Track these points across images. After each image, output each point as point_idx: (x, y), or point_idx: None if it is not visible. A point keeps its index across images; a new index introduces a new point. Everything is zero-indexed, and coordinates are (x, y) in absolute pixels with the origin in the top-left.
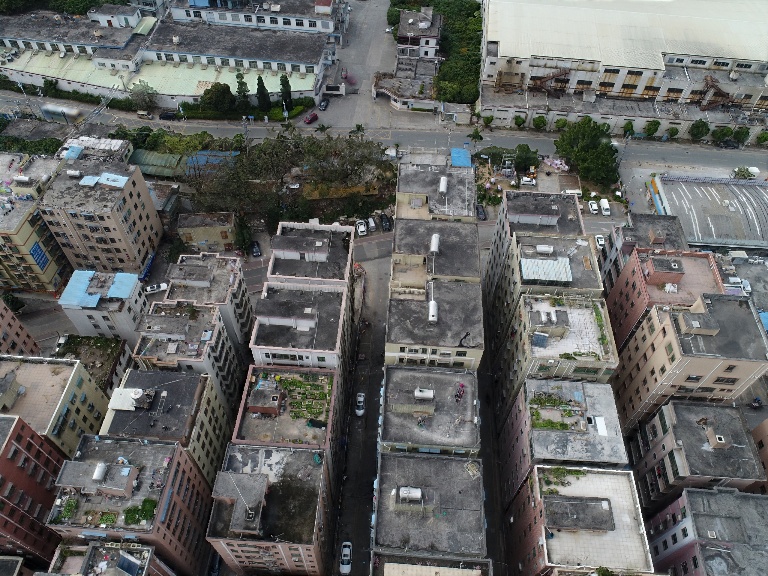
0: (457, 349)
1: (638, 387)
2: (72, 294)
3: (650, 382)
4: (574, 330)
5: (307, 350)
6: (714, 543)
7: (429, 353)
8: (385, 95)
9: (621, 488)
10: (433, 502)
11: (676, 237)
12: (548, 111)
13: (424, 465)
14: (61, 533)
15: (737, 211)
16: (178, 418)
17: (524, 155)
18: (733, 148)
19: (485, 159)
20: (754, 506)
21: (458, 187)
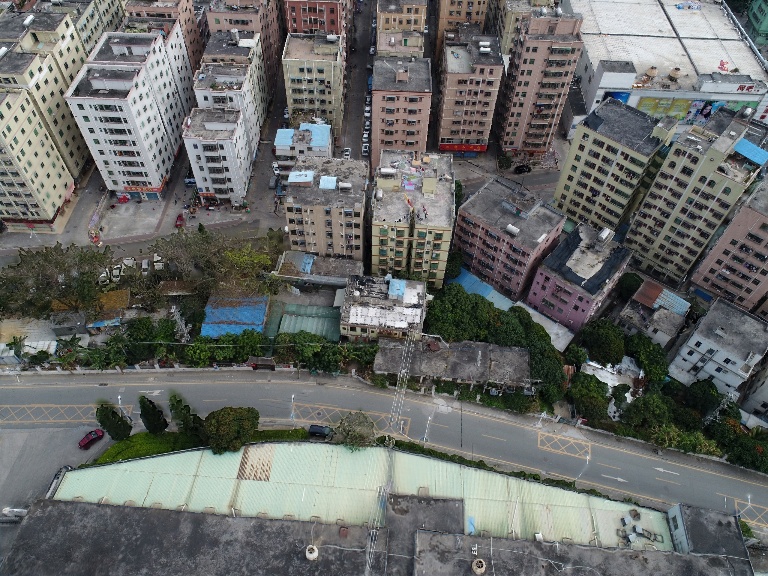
0: None
1: None
2: (322, 130)
3: None
4: None
5: (124, 33)
6: None
7: None
8: None
9: None
10: None
11: None
12: None
13: None
14: None
15: None
16: (215, 38)
17: None
18: None
19: None
20: None
21: None
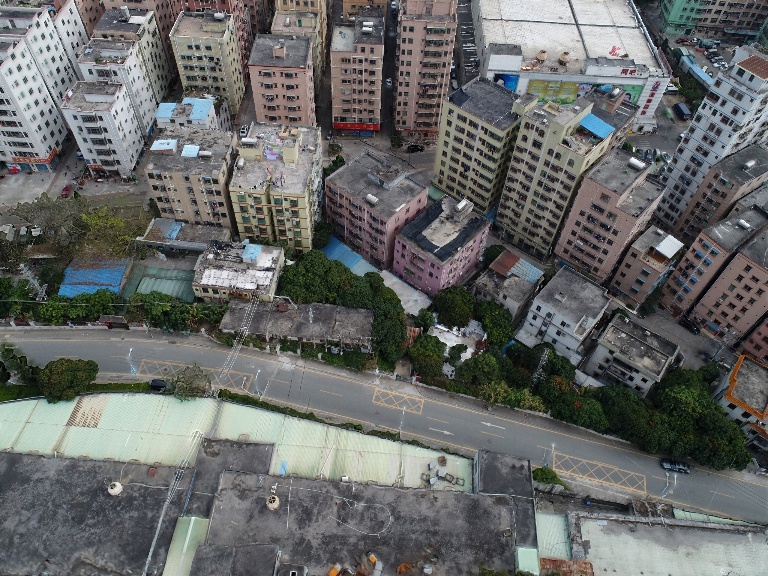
0: None
1: None
2: (203, 104)
3: None
4: None
5: (11, 7)
6: None
7: None
8: None
9: None
10: None
11: None
12: None
13: None
14: None
15: None
16: (107, 15)
17: None
18: None
19: None
20: None
21: None
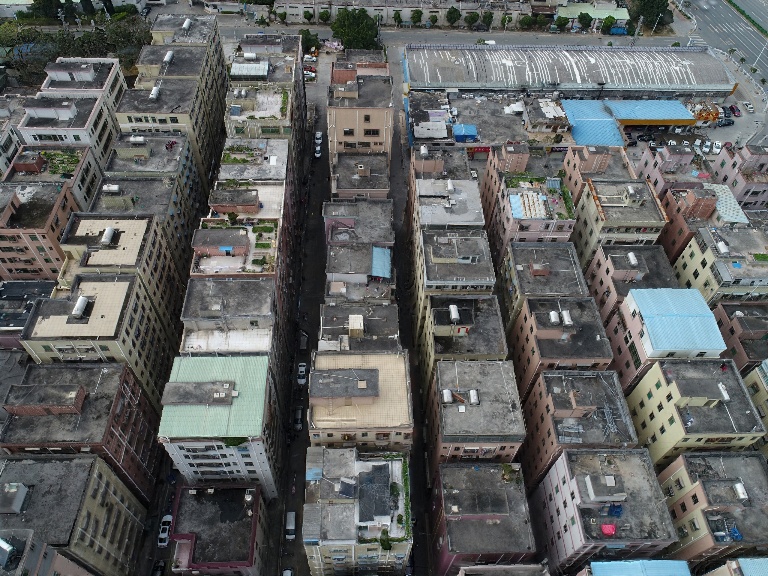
0: (169, 115)
1: None
2: None
3: None
4: (259, 101)
5: (62, 128)
6: (339, 221)
7: (150, 121)
8: (201, 3)
9: (277, 192)
10: (129, 195)
11: None
12: (330, 6)
13: (134, 184)
14: None
15: (461, 64)
16: None
17: (304, 37)
18: (484, 31)
19: None
20: (381, 207)
21: (200, 27)
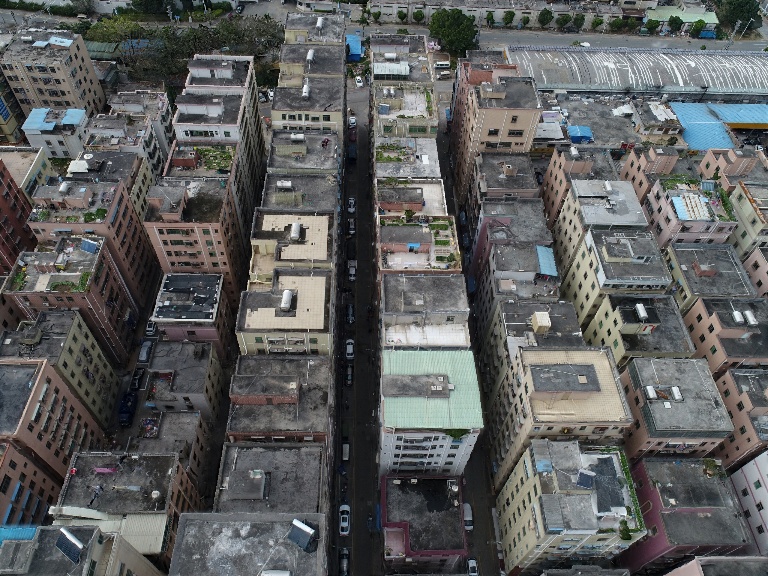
0: (323, 113)
1: (465, 156)
2: (32, 123)
3: (468, 145)
4: (407, 100)
5: (215, 124)
6: (497, 220)
7: (303, 119)
8: (292, 1)
9: (435, 190)
10: (300, 191)
11: None
12: (424, 6)
13: (298, 180)
14: (38, 235)
15: (564, 66)
16: (121, 176)
17: None
18: (574, 33)
19: None
20: (530, 206)
21: (332, 26)
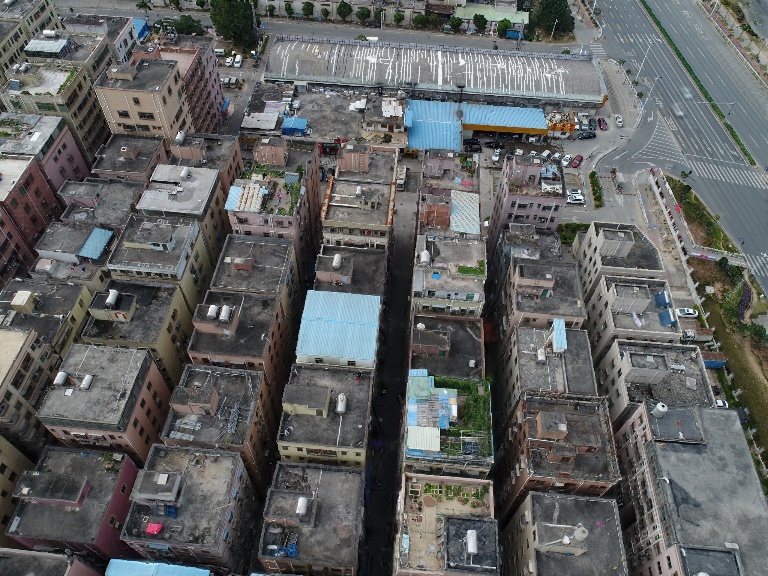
0: None
1: None
2: None
3: None
4: (37, 77)
5: None
6: (78, 200)
7: None
8: None
9: (24, 166)
10: None
11: (206, 50)
12: None
13: None
14: None
15: (323, 58)
16: None
17: (184, 23)
18: (376, 27)
19: (159, 28)
20: (134, 190)
21: (25, 3)
